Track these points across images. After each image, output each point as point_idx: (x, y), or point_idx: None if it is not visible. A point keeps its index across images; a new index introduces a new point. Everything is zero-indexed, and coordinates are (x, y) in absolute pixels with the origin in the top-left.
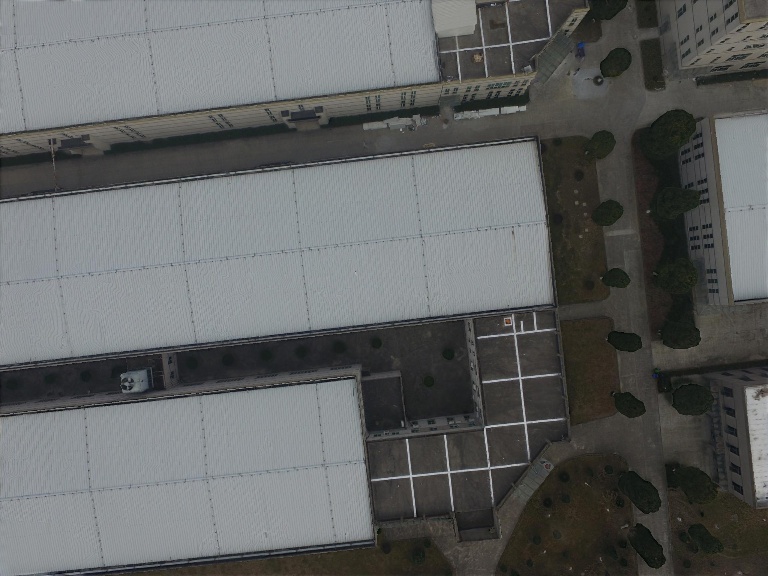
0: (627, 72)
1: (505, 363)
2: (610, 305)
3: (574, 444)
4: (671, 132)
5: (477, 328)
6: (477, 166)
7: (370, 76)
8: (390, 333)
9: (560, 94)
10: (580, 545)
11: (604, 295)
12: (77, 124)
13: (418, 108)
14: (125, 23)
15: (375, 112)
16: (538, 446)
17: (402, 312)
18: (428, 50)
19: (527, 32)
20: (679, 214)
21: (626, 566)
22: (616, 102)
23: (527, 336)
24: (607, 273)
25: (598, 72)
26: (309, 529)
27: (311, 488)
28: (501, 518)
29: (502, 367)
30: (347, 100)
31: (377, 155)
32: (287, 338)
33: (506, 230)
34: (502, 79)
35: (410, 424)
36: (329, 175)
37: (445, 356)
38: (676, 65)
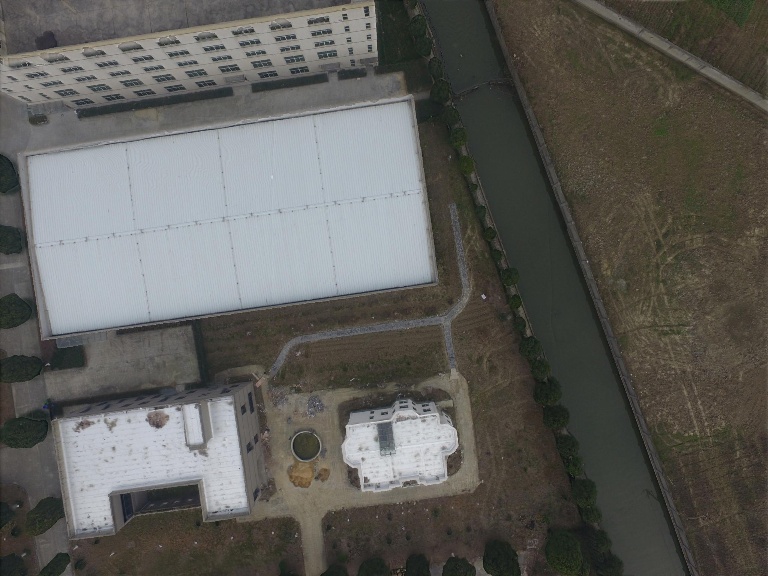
0: (12, 107)
1: None
2: (3, 337)
3: None
4: None
5: None
6: None
7: None
8: None
9: None
10: None
11: None
12: None
13: None
14: None
15: None
16: None
17: None
18: None
19: None
20: None
21: None
22: (2, 137)
23: None
24: None
25: None
26: None
27: None
28: None
29: None
30: None
31: None
32: None
33: None
34: None
35: None
36: None
37: None
38: None
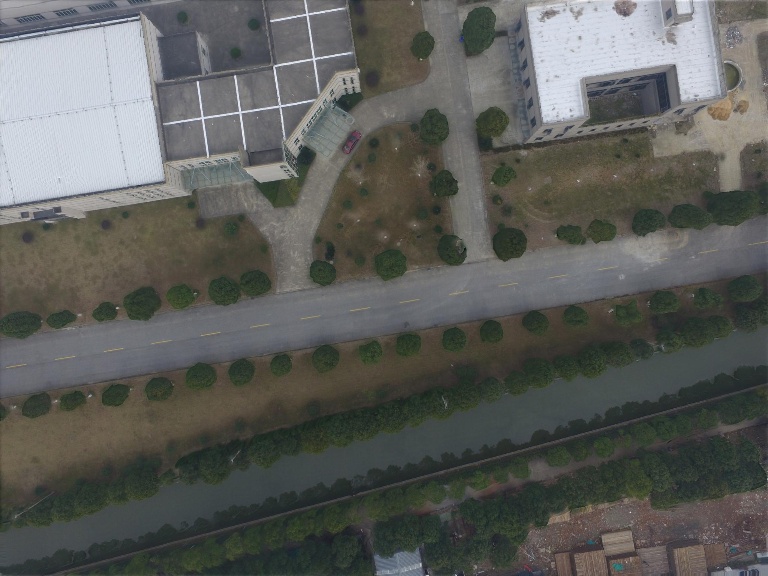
0: None
1: (292, 0)
2: None
3: (384, 113)
4: None
5: None
6: None
7: None
8: (197, 10)
9: None
10: (393, 212)
11: None
12: None
13: None
14: None
15: None
16: (327, 81)
17: None
18: None
19: None
20: None
21: (442, 234)
22: None
23: None
24: None
25: None
26: (102, 173)
27: (101, 129)
28: (315, 191)
29: (289, 5)
30: None
31: None
32: None
33: None
34: None
35: None
36: None
37: (249, 25)
38: None
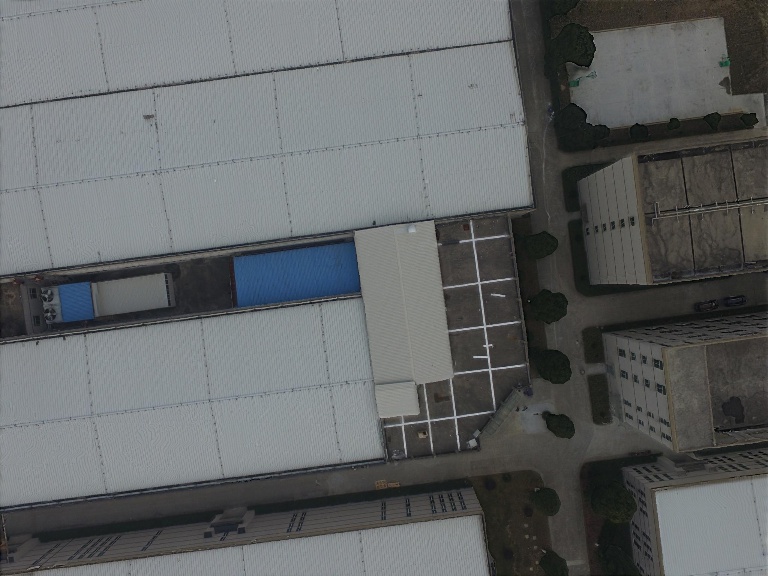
0: (575, 406)
1: None
2: None
3: None
4: (612, 515)
5: None
6: (424, 541)
7: (317, 447)
8: None
9: (509, 429)
10: None
11: None
12: (26, 503)
13: None
14: (70, 407)
15: None
16: None
17: None
18: (373, 428)
19: (471, 405)
20: (627, 547)
21: None
22: None
23: None
24: None
25: (547, 407)
26: None
27: None
28: None
29: None
30: None
31: (325, 532)
32: None
33: None
34: None
35: None
36: (278, 551)
37: None
38: (621, 417)
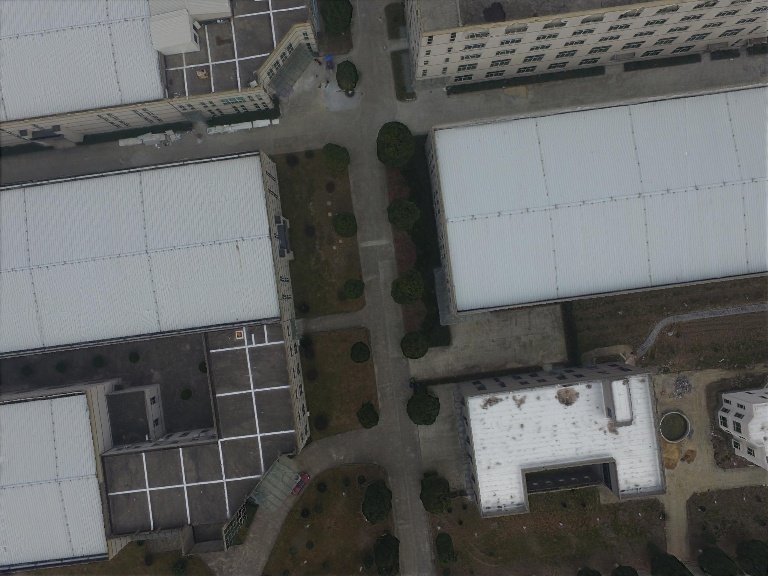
0: (378, 83)
1: (237, 376)
2: (366, 315)
3: (333, 454)
4: (386, 144)
5: (209, 342)
6: (203, 181)
7: (102, 94)
8: (149, 347)
9: (312, 106)
10: (340, 555)
11: (359, 305)
12: None
13: (170, 124)
14: None
15: (128, 128)
16: (271, 458)
17: (128, 327)
18: (153, 68)
19: (252, 47)
20: (430, 224)
21: None
22: (368, 113)
23: (258, 349)
24: (344, 284)
25: None
26: (47, 543)
27: (46, 503)
28: (263, 529)
29: (235, 380)
30: (80, 118)
31: (104, 173)
32: (18, 355)
33: (230, 244)
34: (229, 95)
35: (159, 437)
36: (59, 193)
37: (200, 369)
38: (414, 76)
